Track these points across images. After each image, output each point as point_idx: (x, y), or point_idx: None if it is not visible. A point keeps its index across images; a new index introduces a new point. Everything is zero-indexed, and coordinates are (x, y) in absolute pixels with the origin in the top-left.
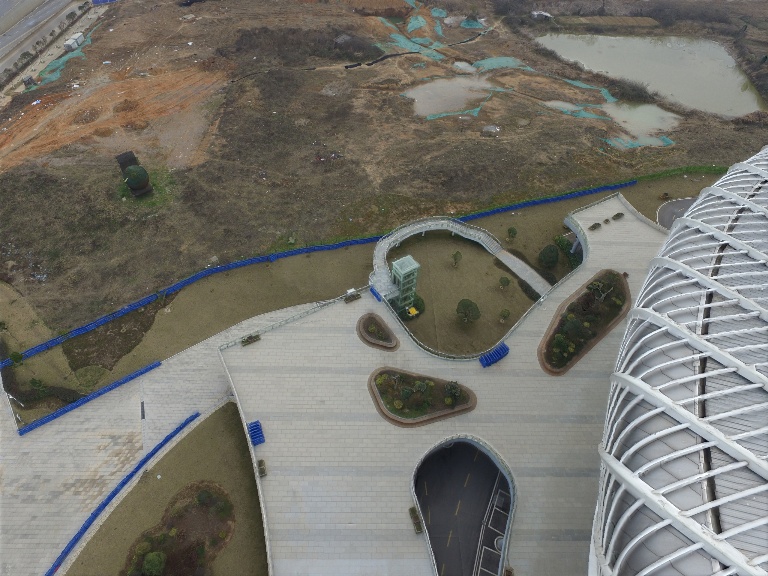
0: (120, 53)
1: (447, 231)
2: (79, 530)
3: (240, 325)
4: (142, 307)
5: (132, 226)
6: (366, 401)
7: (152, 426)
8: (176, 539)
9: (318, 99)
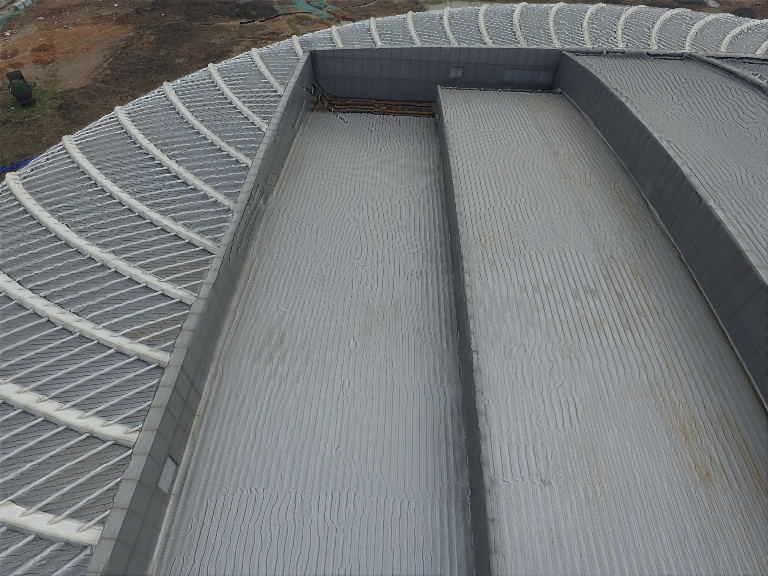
0: (54, 12)
1: None
2: None
3: None
4: None
5: (11, 125)
6: None
7: None
8: None
9: (204, 45)
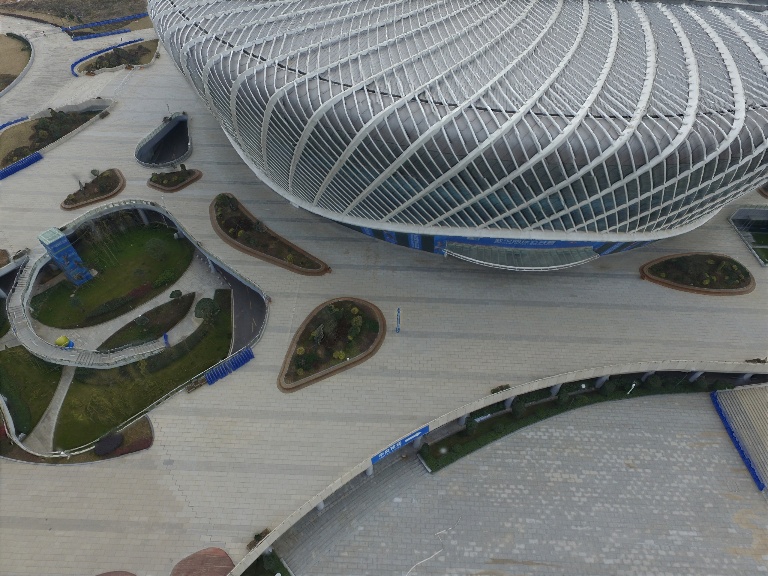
0: None
1: None
2: (95, 54)
3: None
4: (125, 20)
5: (124, 1)
6: None
7: None
8: (129, 53)
9: None
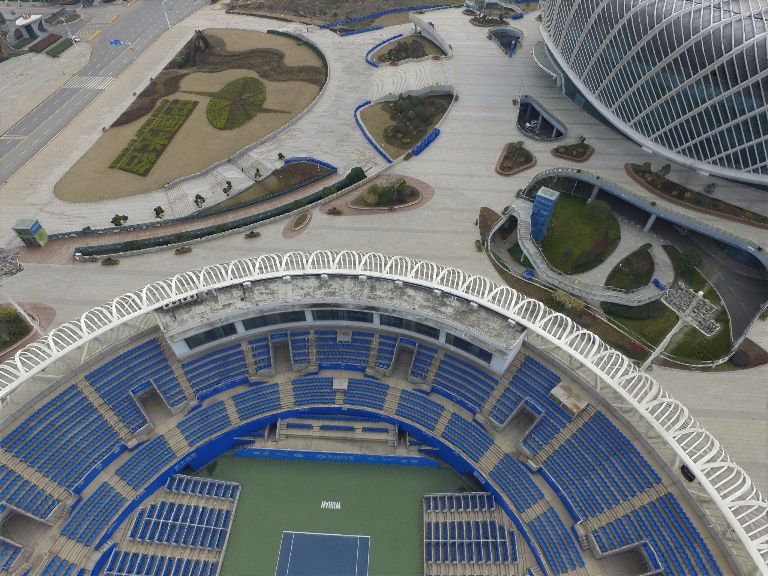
0: None
1: (496, 7)
2: None
3: (410, 23)
4: (368, 19)
5: (352, 2)
6: (468, 23)
7: (387, 37)
8: None
9: None
